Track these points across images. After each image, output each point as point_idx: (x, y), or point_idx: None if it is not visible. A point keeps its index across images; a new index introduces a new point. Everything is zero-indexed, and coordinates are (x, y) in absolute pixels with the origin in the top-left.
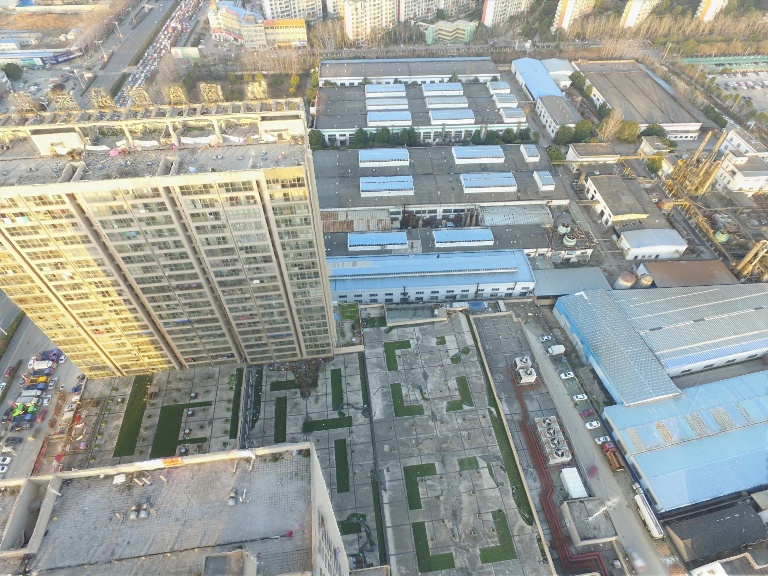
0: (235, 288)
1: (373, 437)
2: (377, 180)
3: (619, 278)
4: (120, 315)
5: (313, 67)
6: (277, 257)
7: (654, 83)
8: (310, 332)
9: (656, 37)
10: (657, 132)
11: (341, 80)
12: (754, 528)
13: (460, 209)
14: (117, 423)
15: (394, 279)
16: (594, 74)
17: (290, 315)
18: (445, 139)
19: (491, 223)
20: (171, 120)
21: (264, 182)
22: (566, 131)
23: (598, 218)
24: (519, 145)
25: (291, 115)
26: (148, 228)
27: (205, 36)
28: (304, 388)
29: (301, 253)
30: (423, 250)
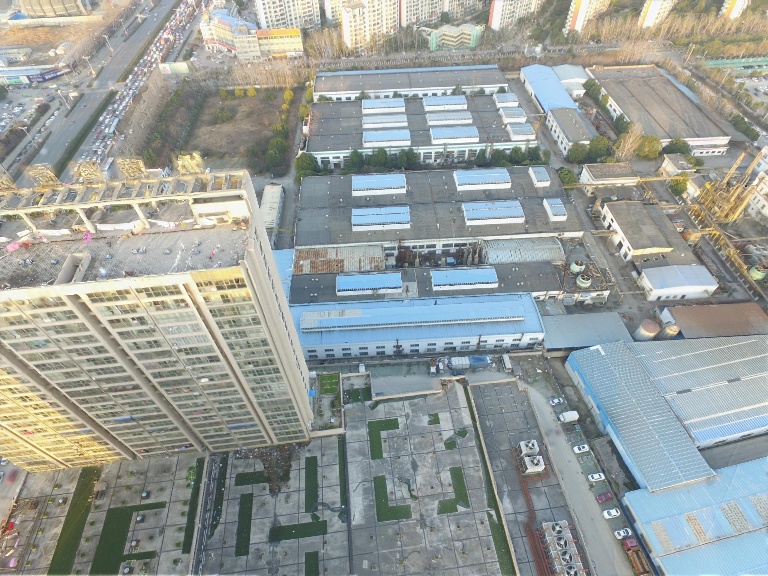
0: (180, 387)
1: (350, 550)
2: (370, 212)
3: (640, 327)
4: (49, 417)
5: (308, 80)
6: (225, 356)
7: (676, 91)
8: (278, 421)
9: (678, 38)
10: (681, 148)
11: (337, 94)
12: None
13: (462, 243)
14: (56, 531)
15: (386, 330)
16: (610, 82)
17: (251, 408)
18: (447, 159)
19: (496, 260)
20: (80, 207)
21: (193, 285)
22: (579, 149)
23: (616, 250)
24: (527, 167)
25: (230, 195)
26: (59, 336)
27: (198, 47)
28: (274, 482)
29: (254, 351)
30: (419, 294)
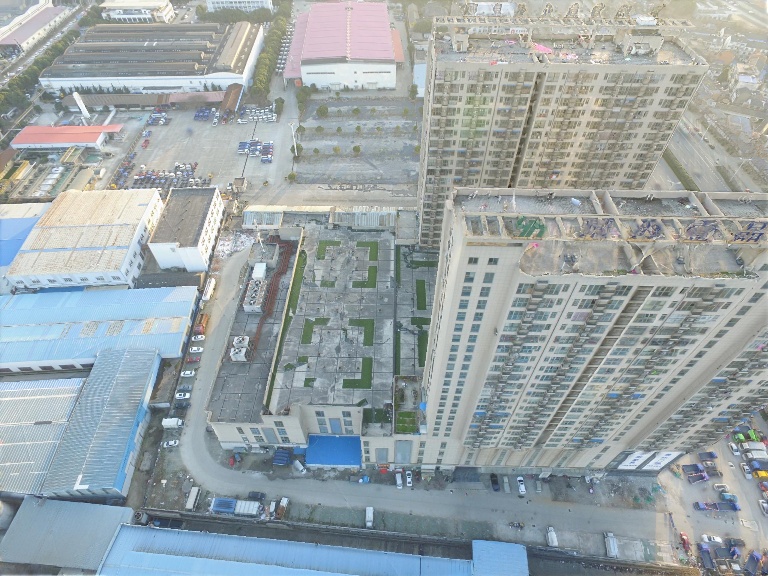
0: None
1: (395, 307)
2: None
3: None
4: None
5: None
6: None
7: None
8: None
9: None
10: None
11: None
12: (148, 276)
13: None
14: None
15: (327, 568)
16: None
17: None
18: None
19: None
20: None
21: None
22: None
23: None
24: None
25: None
26: None
27: None
28: None
29: None
30: None
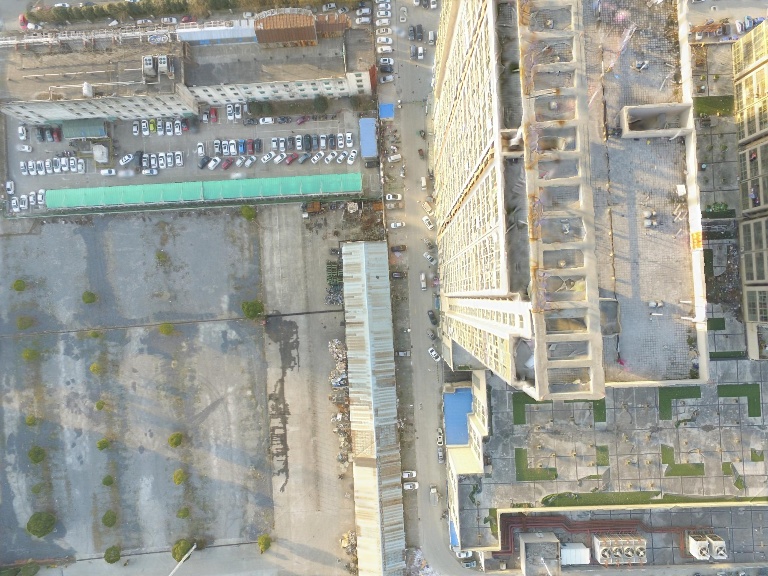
0: None
1: None
2: None
3: None
4: None
5: None
6: None
7: None
8: None
9: None
10: None
11: None
12: None
13: None
14: None
15: None
16: None
17: None
18: None
19: None
20: None
21: None
22: None
23: None
24: None
25: None
26: None
27: None
28: None
29: None
30: None
